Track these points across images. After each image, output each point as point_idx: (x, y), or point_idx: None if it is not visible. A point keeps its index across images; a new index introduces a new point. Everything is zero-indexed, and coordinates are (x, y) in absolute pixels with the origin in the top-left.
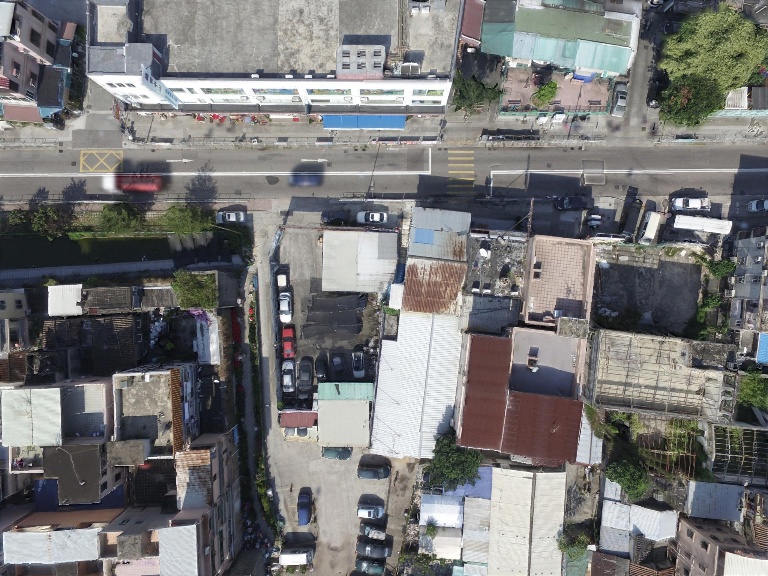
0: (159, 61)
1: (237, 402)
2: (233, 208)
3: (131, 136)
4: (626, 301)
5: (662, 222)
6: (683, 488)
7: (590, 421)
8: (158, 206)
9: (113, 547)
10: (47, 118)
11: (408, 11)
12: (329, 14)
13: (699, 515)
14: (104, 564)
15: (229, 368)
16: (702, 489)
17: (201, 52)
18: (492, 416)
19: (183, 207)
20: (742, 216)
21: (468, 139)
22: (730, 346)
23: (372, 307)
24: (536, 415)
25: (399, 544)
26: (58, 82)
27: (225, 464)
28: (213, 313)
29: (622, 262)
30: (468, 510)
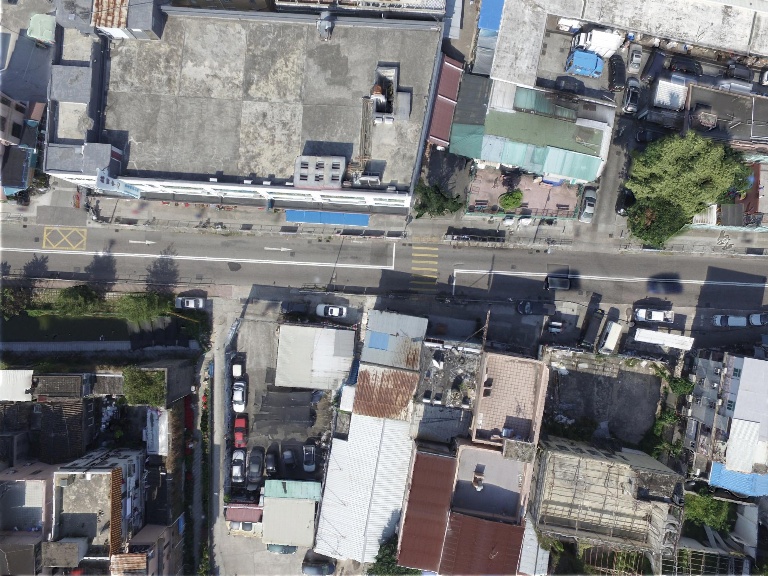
0: (119, 158)
1: (185, 489)
2: (193, 293)
3: (95, 216)
4: (583, 409)
5: (624, 331)
6: None
7: (537, 533)
8: (118, 287)
9: None
10: (11, 196)
11: (372, 120)
12: (292, 119)
13: None
14: None
15: (178, 457)
16: None
17: (162, 151)
18: (431, 537)
19: (143, 289)
20: (706, 329)
21: (433, 236)
22: (678, 478)
23: (327, 400)
24: (476, 539)
25: None
26: (23, 162)
27: (166, 558)
28: (162, 407)
29: (581, 369)
30: None
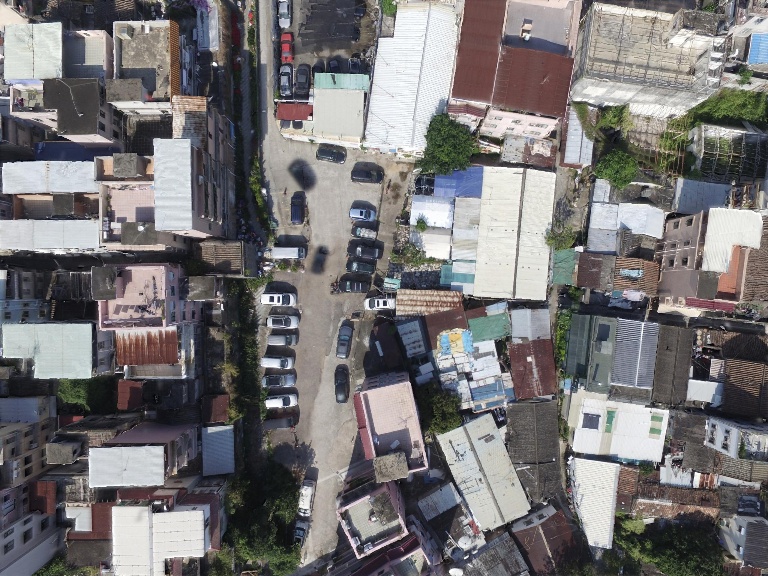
0: None
1: (234, 104)
2: None
3: None
4: None
5: None
6: (671, 188)
7: (581, 121)
8: None
9: (109, 177)
10: None
11: None
12: None
13: (686, 211)
14: (100, 187)
15: (227, 62)
16: (690, 186)
17: None
18: (484, 68)
19: None
20: None
21: None
22: (721, 15)
23: (370, 18)
24: (527, 69)
25: (390, 250)
26: None
27: (221, 142)
28: None
29: None
30: (458, 209)
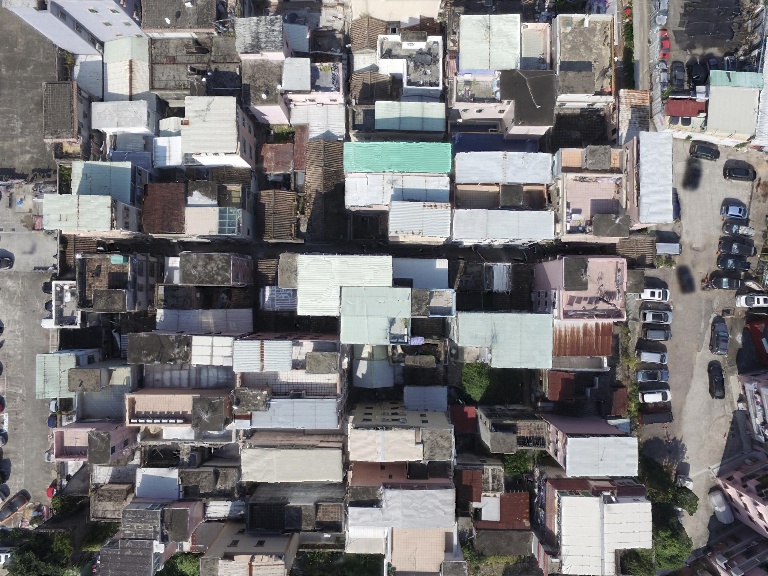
0: None
1: None
2: None
3: None
4: None
5: None
6: None
7: None
8: None
9: (566, 169)
10: None
11: None
12: None
13: None
14: (565, 178)
15: None
16: None
17: None
18: None
19: None
20: None
21: None
22: None
23: (742, 17)
24: None
25: (759, 248)
26: None
27: None
28: None
29: None
30: None
